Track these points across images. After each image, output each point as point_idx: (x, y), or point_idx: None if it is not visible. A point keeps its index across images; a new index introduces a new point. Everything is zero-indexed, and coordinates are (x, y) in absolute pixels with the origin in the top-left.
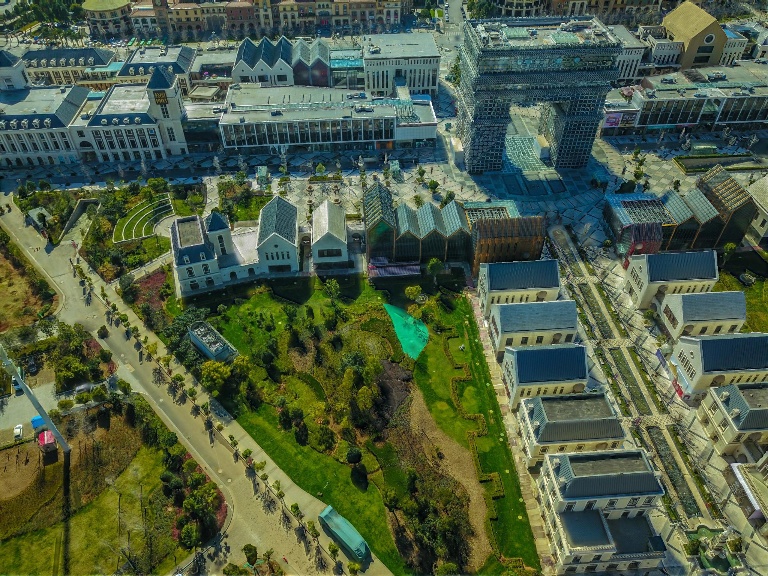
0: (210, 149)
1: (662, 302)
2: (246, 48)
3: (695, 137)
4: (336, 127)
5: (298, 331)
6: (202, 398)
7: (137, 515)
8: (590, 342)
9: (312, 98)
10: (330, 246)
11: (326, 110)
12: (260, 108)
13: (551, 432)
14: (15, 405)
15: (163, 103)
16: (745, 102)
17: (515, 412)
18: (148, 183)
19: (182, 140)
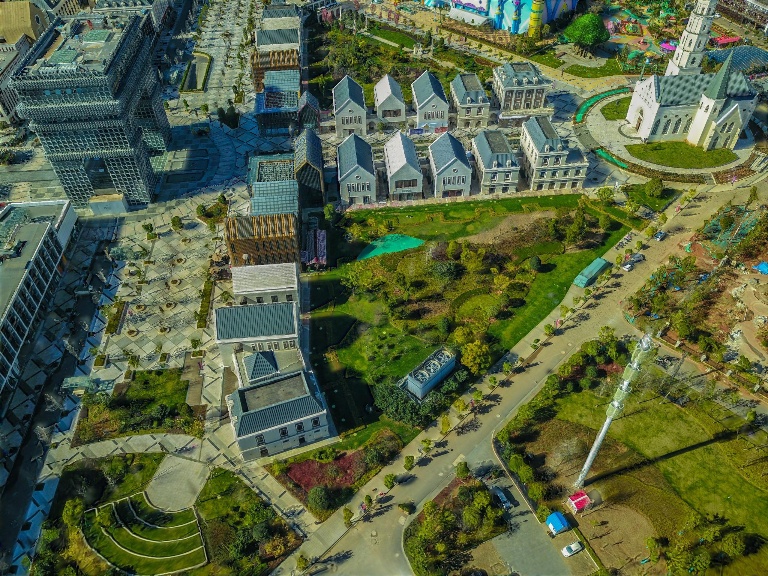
0: None
1: (378, 114)
2: None
3: None
4: (30, 286)
5: None
6: None
7: (623, 402)
8: None
9: None
10: None
11: None
12: None
13: None
14: (536, 575)
15: None
16: None
17: (471, 194)
18: (75, 523)
19: None
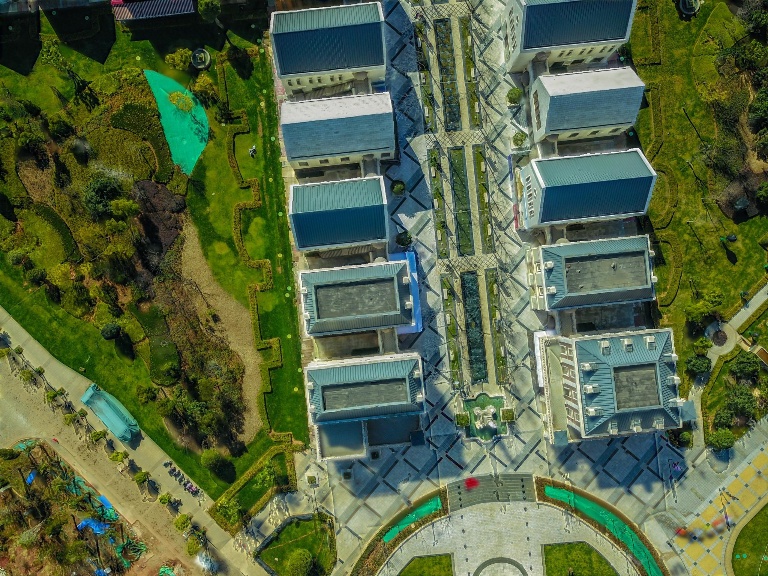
0: None
1: (534, 81)
2: None
3: None
4: None
5: None
6: None
7: None
8: (426, 138)
9: None
10: None
11: None
12: None
13: (323, 327)
14: None
15: None
16: None
17: (308, 256)
18: None
19: None
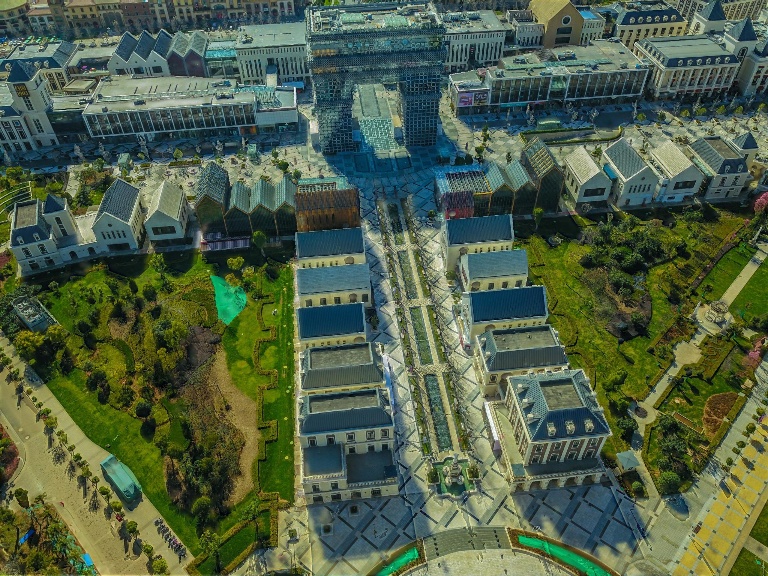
0: (80, 139)
1: (460, 263)
2: (123, 42)
3: (546, 113)
4: (197, 114)
5: (122, 303)
6: (19, 366)
7: None
8: (394, 303)
9: (178, 87)
10: (162, 224)
11: (188, 98)
12: (125, 98)
13: (314, 379)
14: None
15: (25, 96)
16: (589, 79)
17: None
18: (6, 172)
19: (50, 131)
